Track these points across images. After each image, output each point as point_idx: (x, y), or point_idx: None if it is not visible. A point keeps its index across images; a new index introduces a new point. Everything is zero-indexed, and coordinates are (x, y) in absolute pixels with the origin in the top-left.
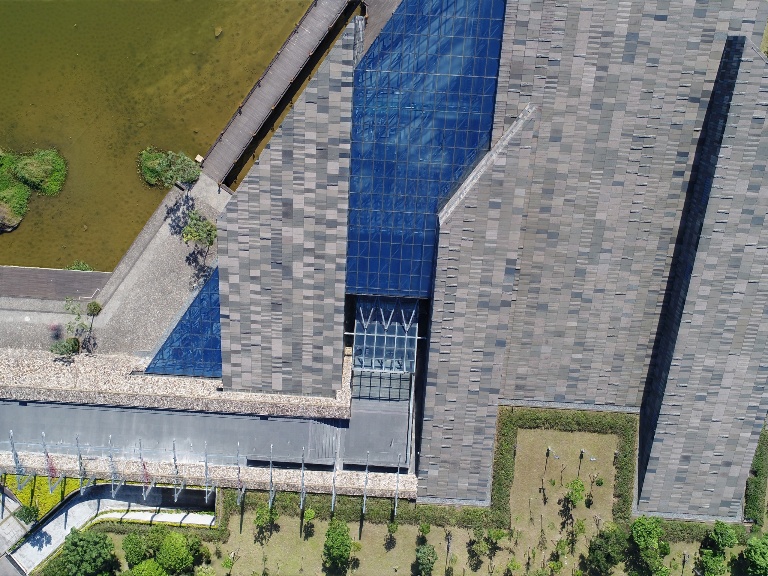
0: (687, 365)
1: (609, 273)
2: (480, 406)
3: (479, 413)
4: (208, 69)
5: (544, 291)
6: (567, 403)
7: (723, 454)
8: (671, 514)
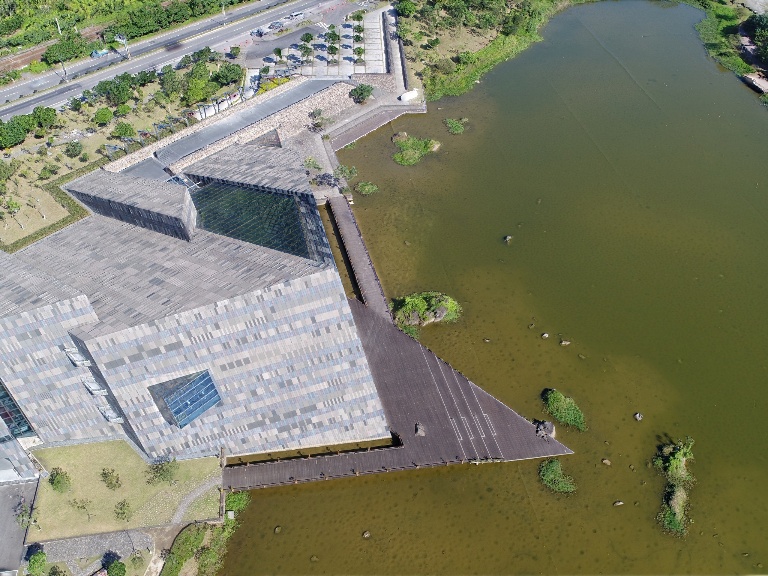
0: None
1: None
2: None
3: None
4: (393, 230)
5: None
6: None
7: None
8: None
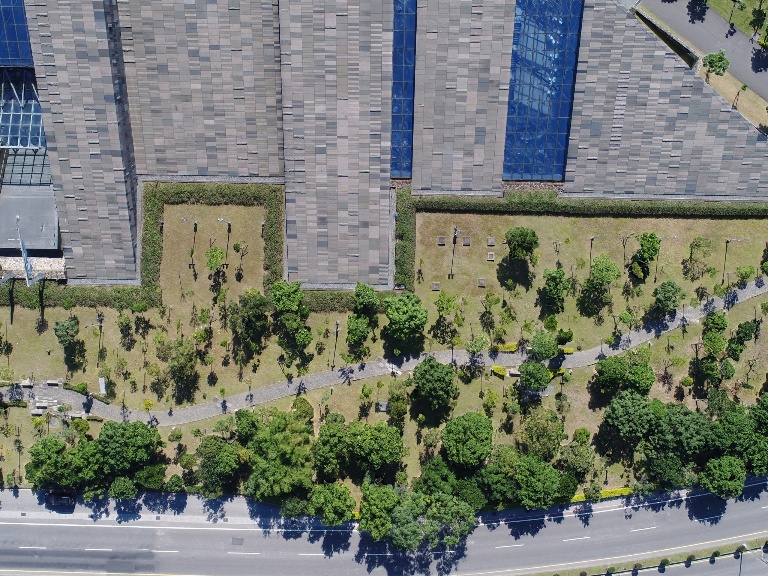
0: (299, 113)
1: (220, 27)
2: (106, 172)
3: (107, 180)
4: None
5: (160, 50)
6: (212, 176)
7: (358, 213)
8: (323, 285)
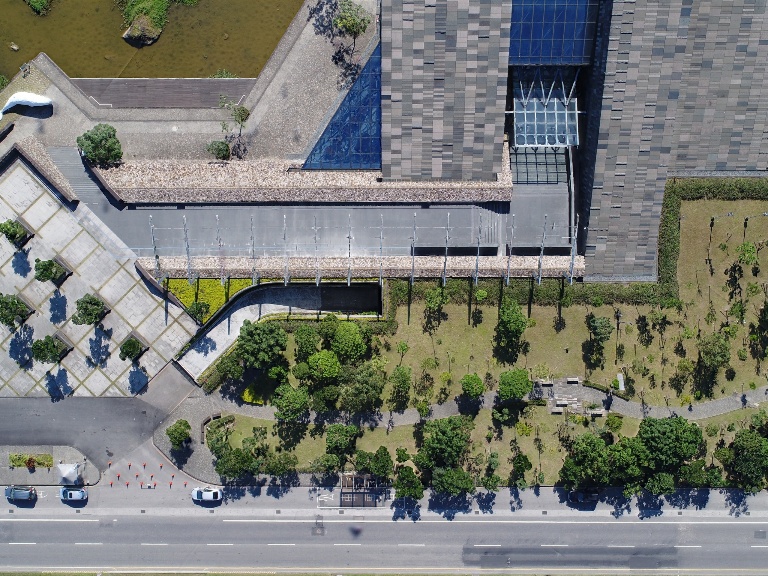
0: None
1: None
2: (650, 168)
3: (649, 176)
4: None
5: (709, 46)
6: (728, 171)
7: None
8: None
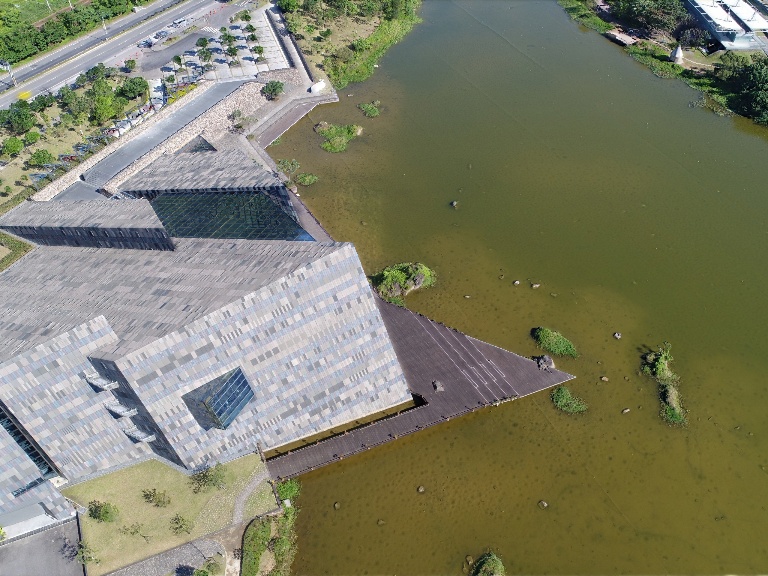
0: None
1: None
2: None
3: None
4: (346, 213)
5: None
6: None
7: None
8: None
